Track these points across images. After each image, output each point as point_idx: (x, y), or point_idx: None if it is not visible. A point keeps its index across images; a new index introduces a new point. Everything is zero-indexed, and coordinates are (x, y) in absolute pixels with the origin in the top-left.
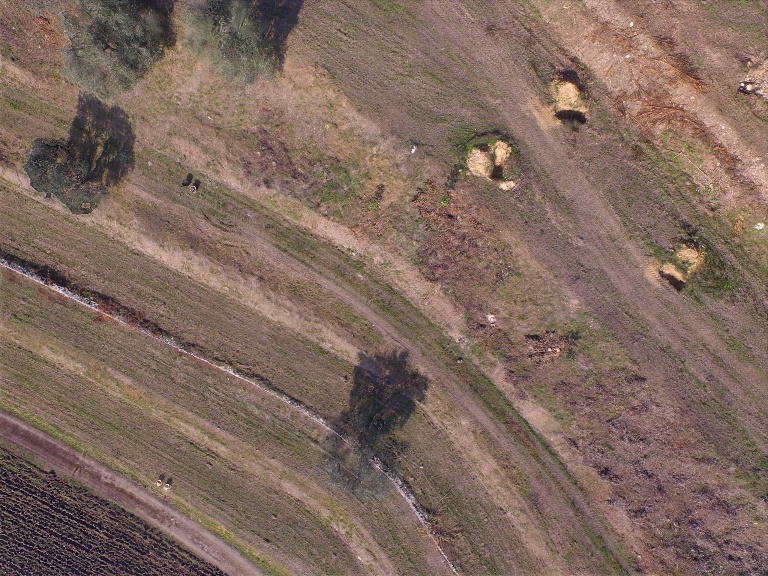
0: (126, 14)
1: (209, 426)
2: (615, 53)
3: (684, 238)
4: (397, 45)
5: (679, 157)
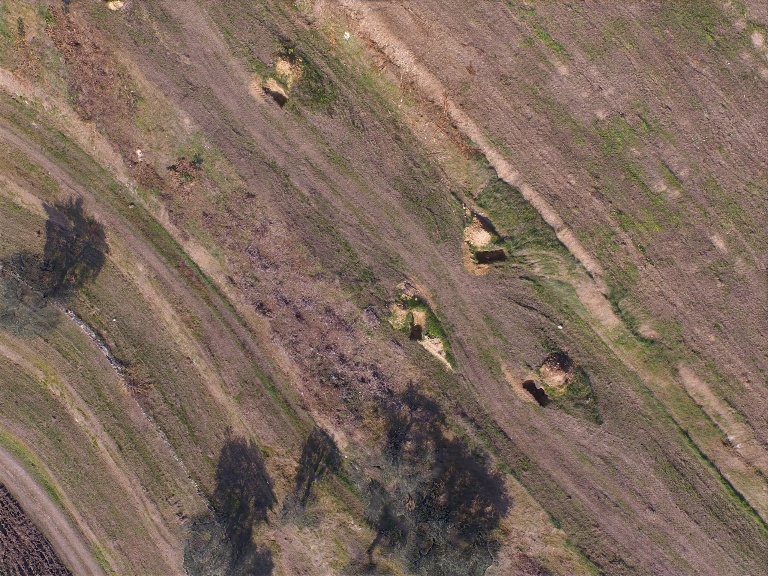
0: None
1: None
2: None
3: (282, 52)
4: None
5: None
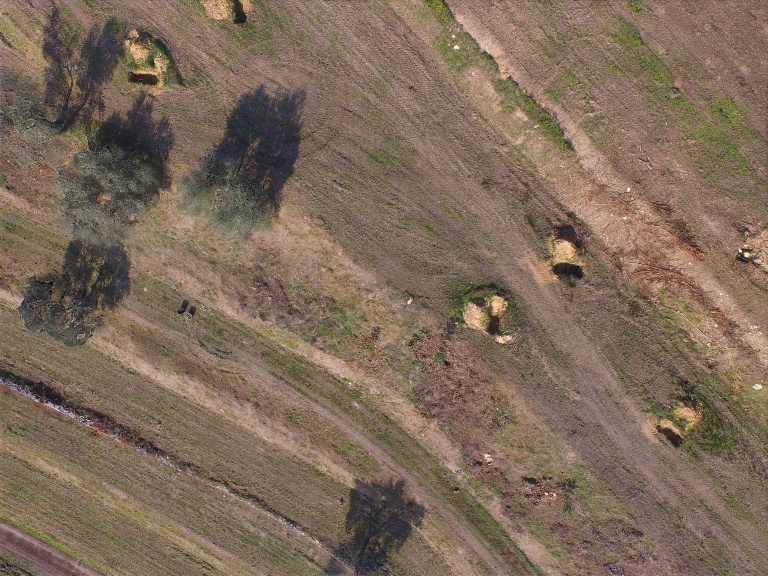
0: (120, 170)
1: (205, 542)
2: (612, 213)
3: (681, 395)
4: (393, 197)
5: (676, 315)
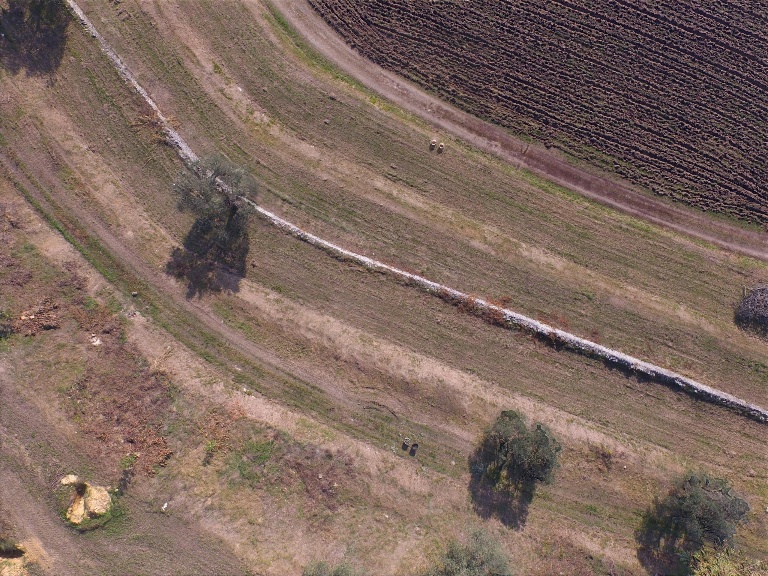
0: None
1: (391, 206)
2: None
3: None
4: None
5: None
